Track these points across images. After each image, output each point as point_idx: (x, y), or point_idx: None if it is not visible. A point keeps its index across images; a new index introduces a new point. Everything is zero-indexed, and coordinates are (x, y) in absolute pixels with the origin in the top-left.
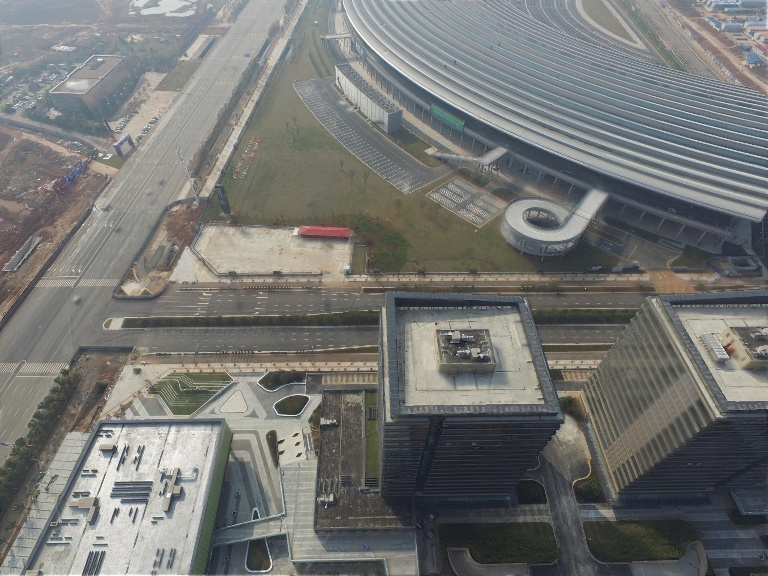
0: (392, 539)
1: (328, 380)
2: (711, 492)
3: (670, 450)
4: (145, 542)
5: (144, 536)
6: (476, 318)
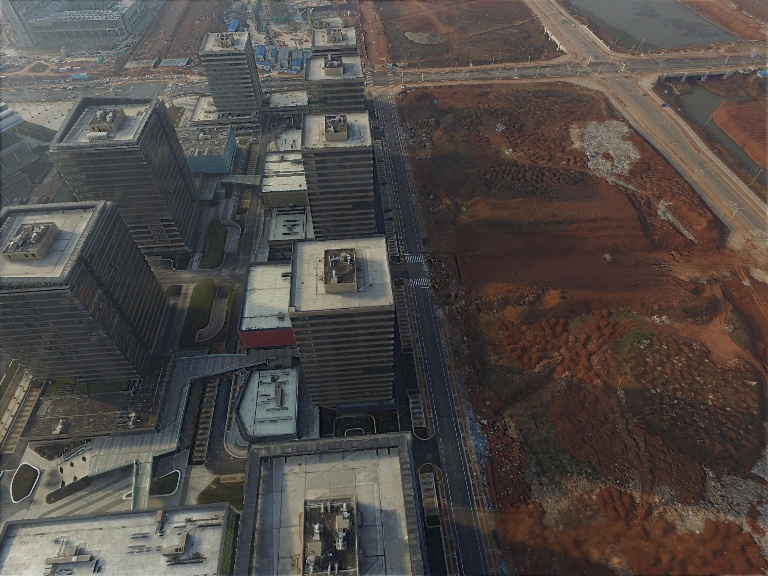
0: (179, 374)
1: (10, 447)
2: (198, 208)
3: (157, 188)
4: (116, 572)
5: (110, 575)
6: (7, 236)
